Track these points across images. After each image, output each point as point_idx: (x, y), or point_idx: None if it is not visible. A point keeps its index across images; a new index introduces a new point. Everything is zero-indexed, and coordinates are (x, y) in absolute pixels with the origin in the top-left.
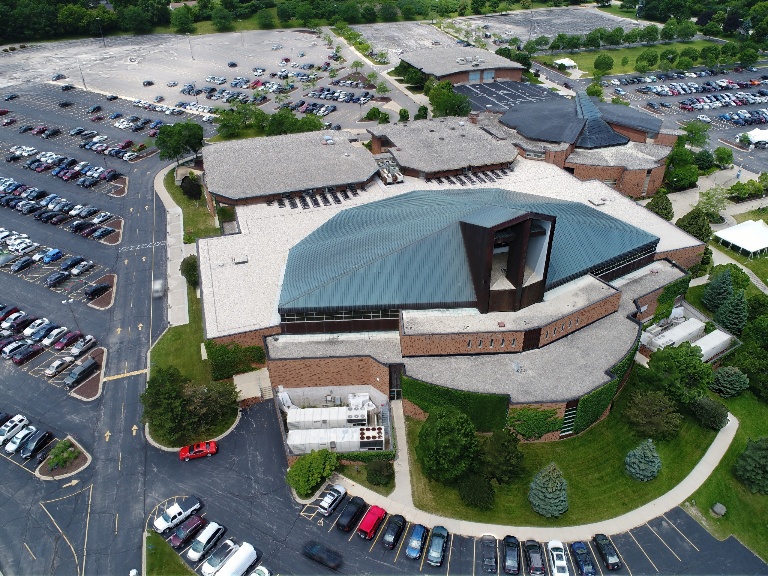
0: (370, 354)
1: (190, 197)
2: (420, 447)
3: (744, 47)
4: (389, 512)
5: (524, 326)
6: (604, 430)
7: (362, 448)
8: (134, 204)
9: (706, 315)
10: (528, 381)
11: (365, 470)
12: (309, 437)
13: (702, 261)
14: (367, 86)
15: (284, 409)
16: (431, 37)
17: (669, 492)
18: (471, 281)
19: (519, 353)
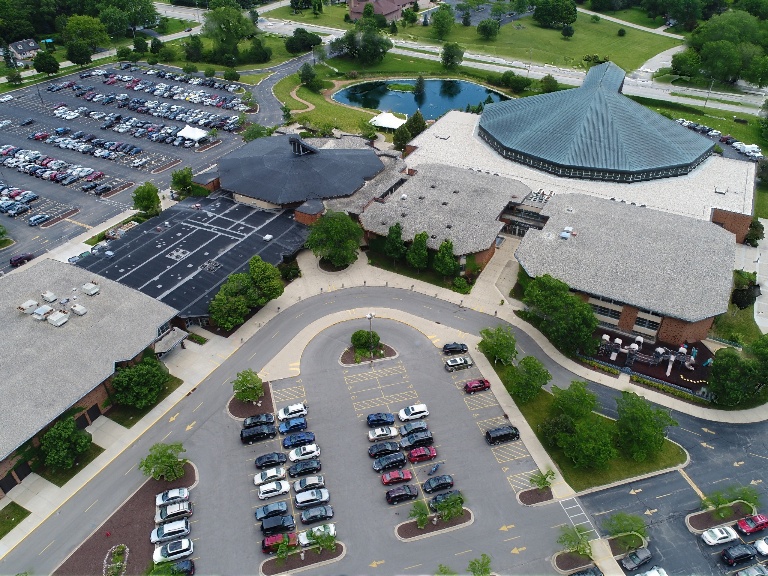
0: None
1: (745, 306)
2: None
3: None
4: None
5: None
6: None
7: None
8: None
9: None
10: None
11: None
12: None
13: None
14: None
15: None
16: None
17: None
18: None
19: None
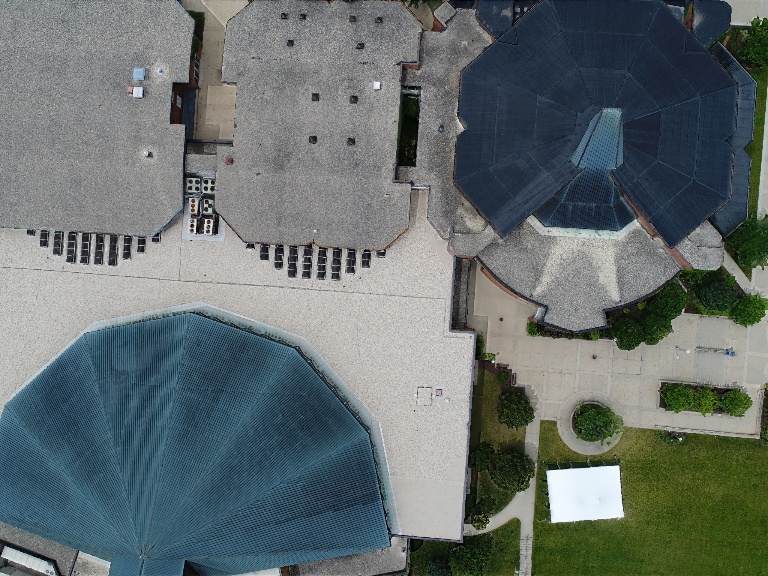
0: (56, 556)
1: None
2: None
3: None
4: None
5: None
6: None
7: None
8: None
9: (423, 572)
10: None
11: None
12: None
13: None
14: None
15: None
16: None
17: None
18: None
19: None
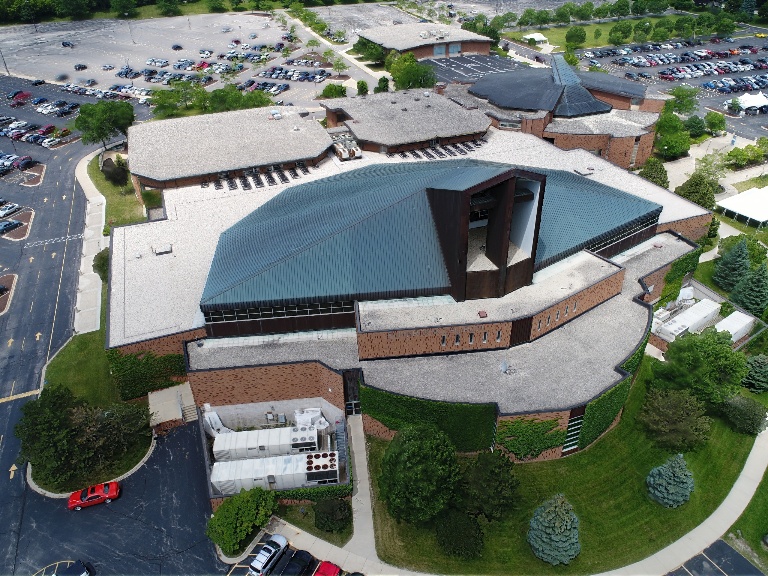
0: (319, 358)
1: (114, 183)
2: (383, 479)
3: (719, 18)
4: (345, 569)
5: (511, 315)
6: (616, 442)
7: (310, 481)
8: (49, 194)
9: None
10: (519, 384)
11: (314, 511)
12: (240, 471)
13: (708, 233)
14: (324, 65)
15: (212, 433)
16: (392, 17)
17: (706, 520)
18: (443, 262)
19: (506, 349)
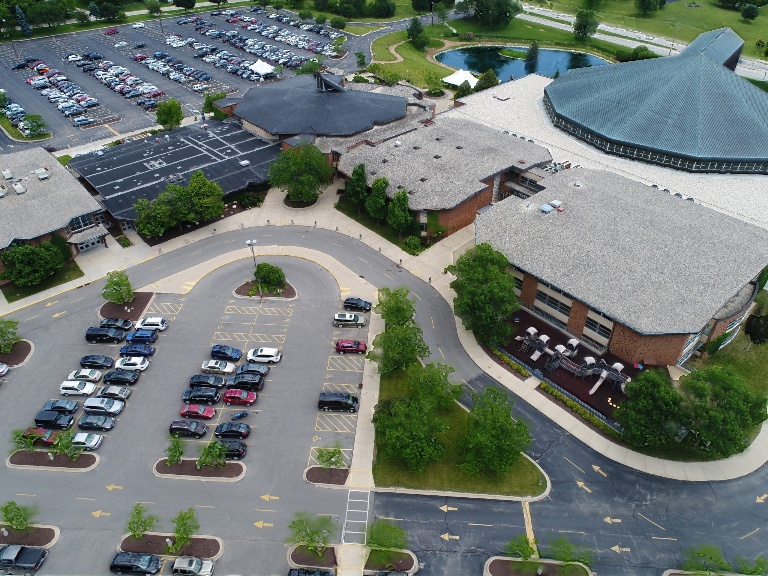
0: None
1: (762, 339)
2: None
3: None
4: None
5: None
6: None
7: None
8: None
9: None
10: None
11: None
12: None
13: None
14: None
15: None
16: None
17: None
18: None
19: None
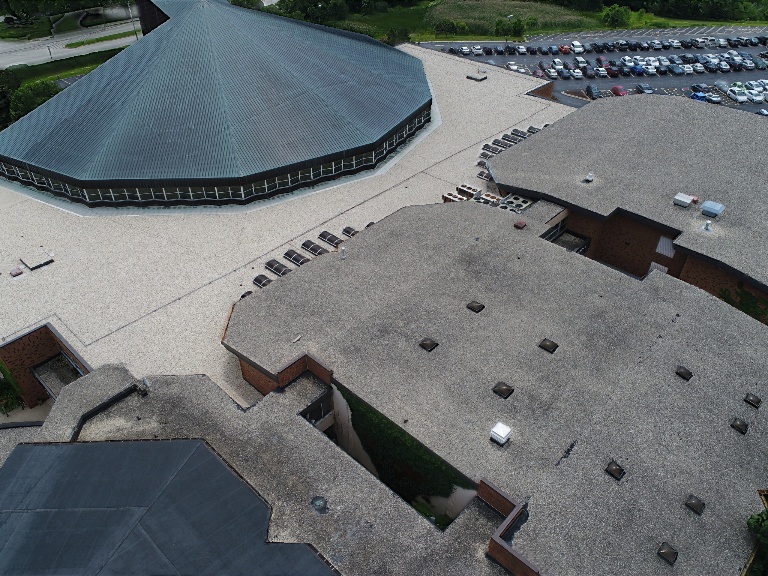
0: None
1: None
2: None
3: None
4: None
5: None
6: None
7: None
8: None
9: None
10: None
11: None
12: None
13: None
14: None
15: None
16: None
17: None
18: None
19: None
